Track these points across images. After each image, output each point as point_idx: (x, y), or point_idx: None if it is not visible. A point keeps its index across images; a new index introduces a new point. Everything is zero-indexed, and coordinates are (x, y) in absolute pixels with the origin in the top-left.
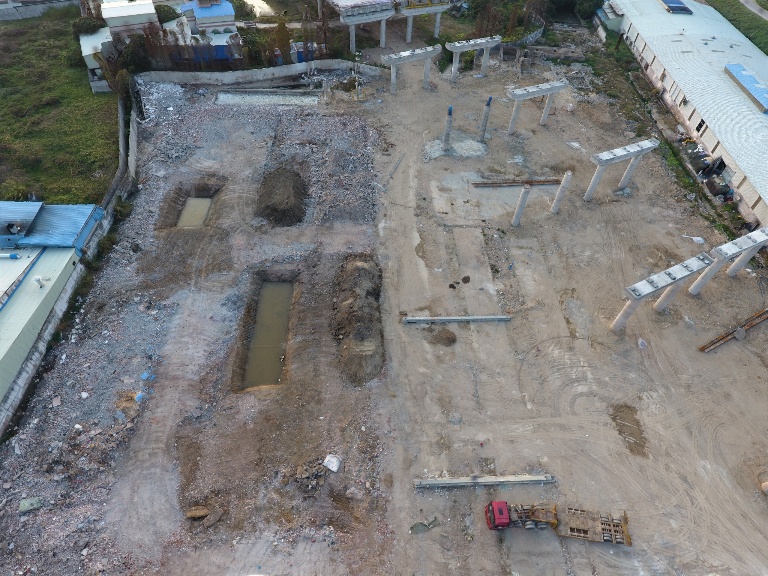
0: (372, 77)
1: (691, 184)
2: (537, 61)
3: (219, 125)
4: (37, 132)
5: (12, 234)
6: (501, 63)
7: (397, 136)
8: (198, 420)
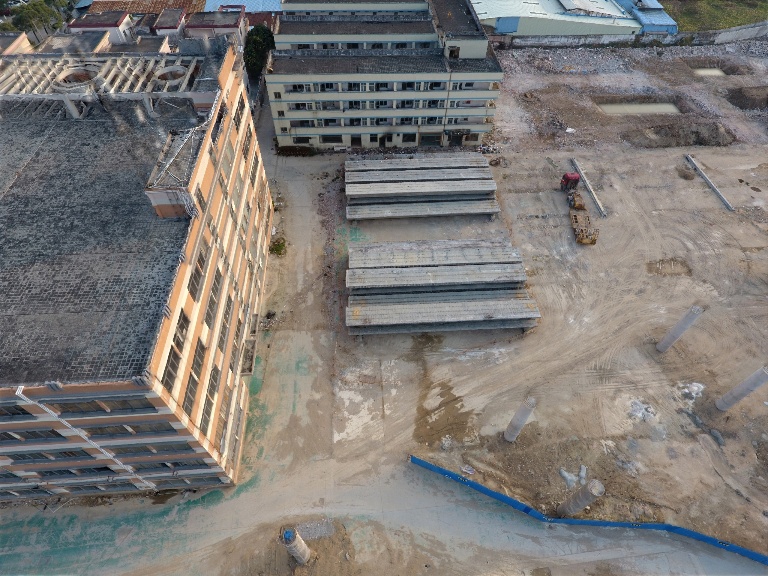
0: None
1: None
2: None
3: None
4: (720, 8)
5: (636, 5)
6: None
7: None
8: (570, 89)
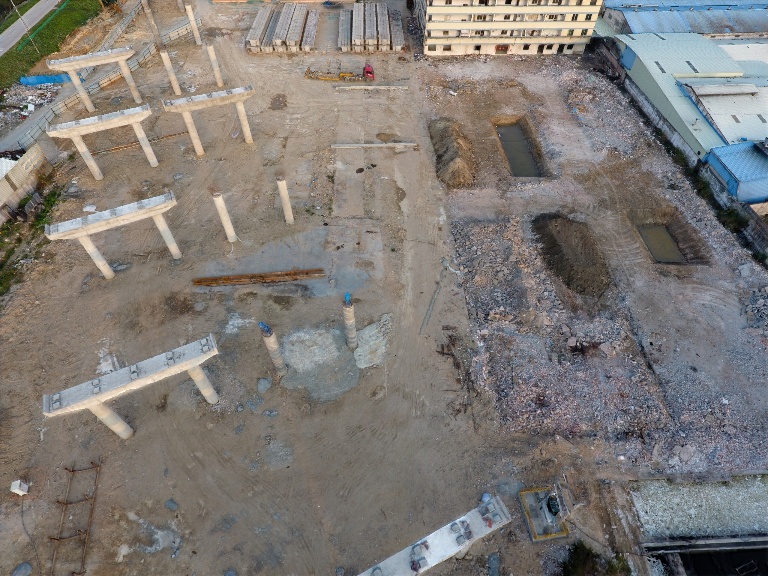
0: None
1: None
2: None
3: None
4: None
5: None
6: None
7: (436, 377)
8: None
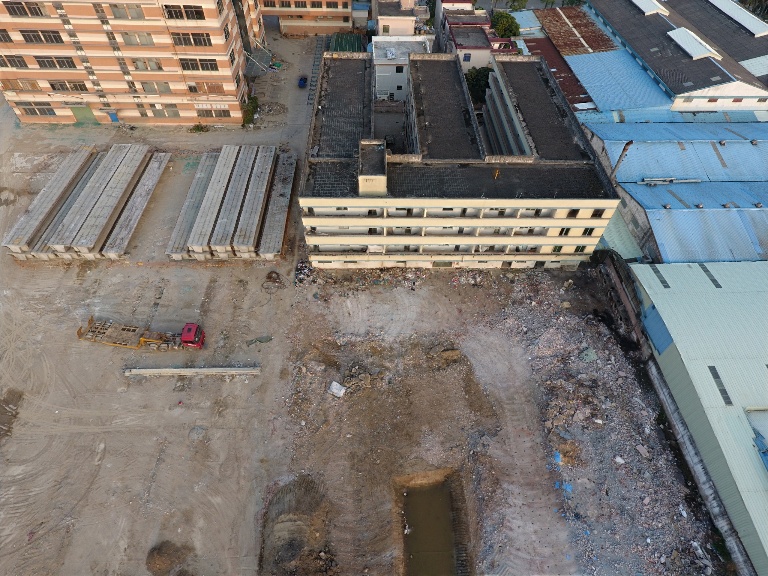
0: None
1: None
2: None
3: None
4: None
5: None
6: None
7: None
8: (482, 433)
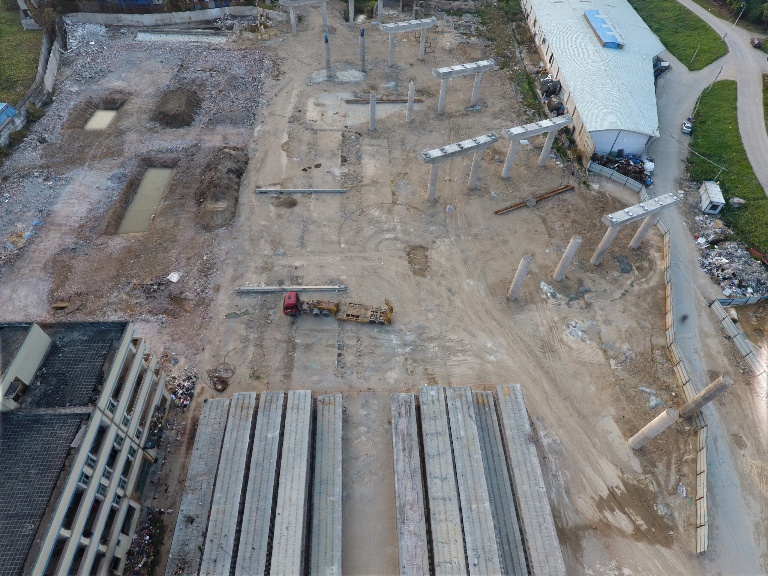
0: (280, 22)
1: (534, 103)
2: (432, 12)
3: (133, 56)
4: None
5: None
6: (400, 13)
7: (290, 66)
8: (73, 251)
